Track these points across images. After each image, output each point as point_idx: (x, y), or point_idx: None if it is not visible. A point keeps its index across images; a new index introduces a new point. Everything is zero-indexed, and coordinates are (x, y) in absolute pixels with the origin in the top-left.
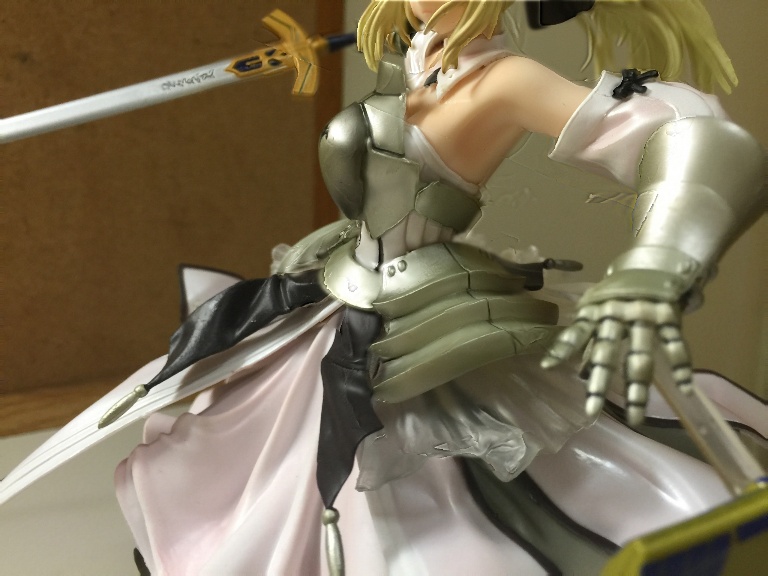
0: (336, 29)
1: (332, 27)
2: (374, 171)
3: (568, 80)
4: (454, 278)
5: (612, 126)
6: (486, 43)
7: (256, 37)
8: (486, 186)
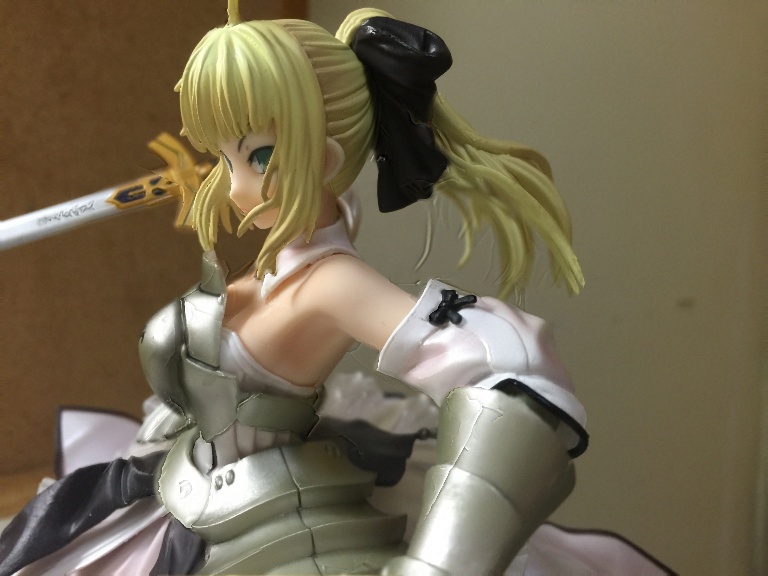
0: None
1: None
2: (192, 379)
3: (397, 285)
4: (282, 497)
5: (428, 356)
6: (315, 237)
7: (142, 163)
8: (324, 385)
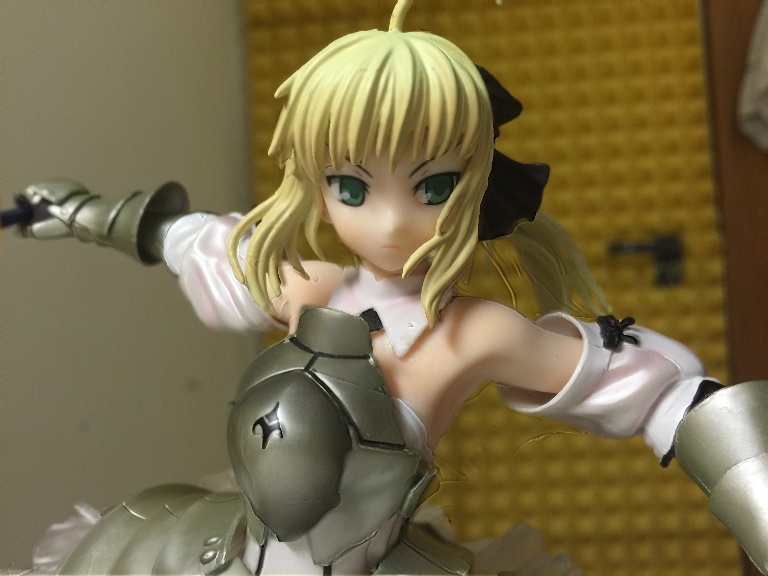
0: None
1: None
2: (354, 473)
3: None
4: None
5: (614, 380)
6: None
7: None
8: None
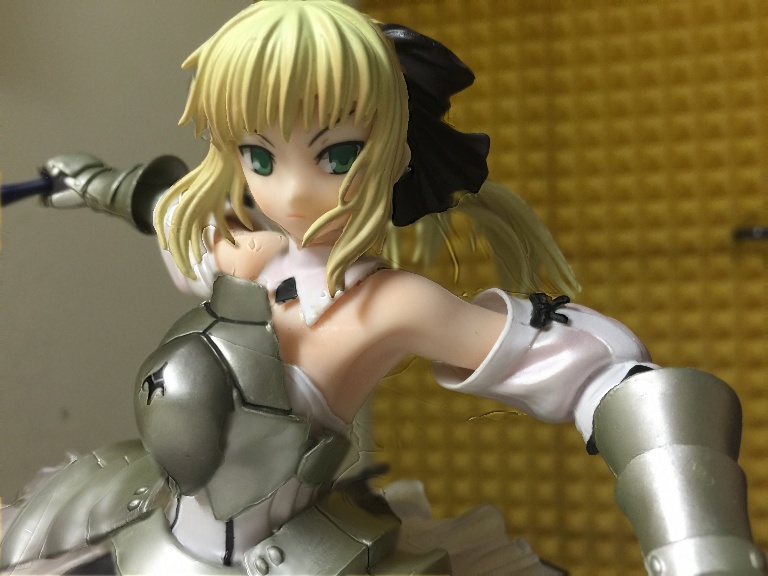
0: (11, 176)
1: (5, 174)
2: (240, 434)
3: None
4: (353, 559)
5: (537, 359)
6: None
7: None
8: (357, 421)
